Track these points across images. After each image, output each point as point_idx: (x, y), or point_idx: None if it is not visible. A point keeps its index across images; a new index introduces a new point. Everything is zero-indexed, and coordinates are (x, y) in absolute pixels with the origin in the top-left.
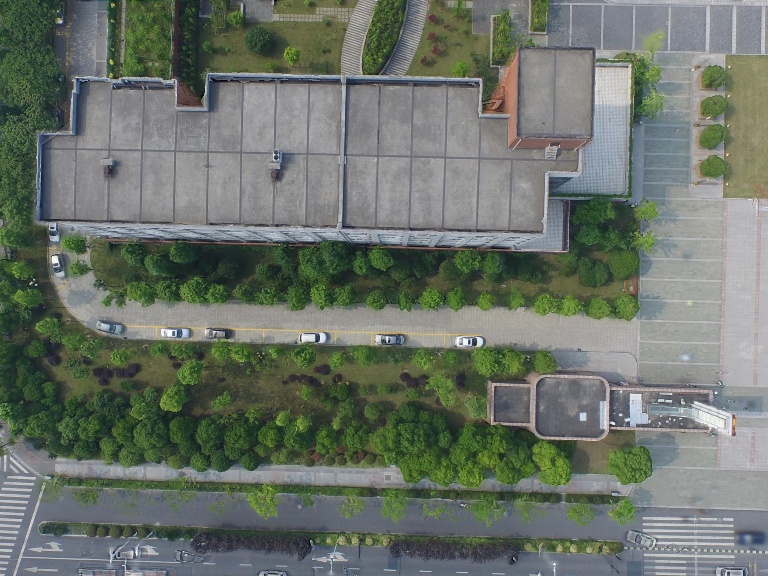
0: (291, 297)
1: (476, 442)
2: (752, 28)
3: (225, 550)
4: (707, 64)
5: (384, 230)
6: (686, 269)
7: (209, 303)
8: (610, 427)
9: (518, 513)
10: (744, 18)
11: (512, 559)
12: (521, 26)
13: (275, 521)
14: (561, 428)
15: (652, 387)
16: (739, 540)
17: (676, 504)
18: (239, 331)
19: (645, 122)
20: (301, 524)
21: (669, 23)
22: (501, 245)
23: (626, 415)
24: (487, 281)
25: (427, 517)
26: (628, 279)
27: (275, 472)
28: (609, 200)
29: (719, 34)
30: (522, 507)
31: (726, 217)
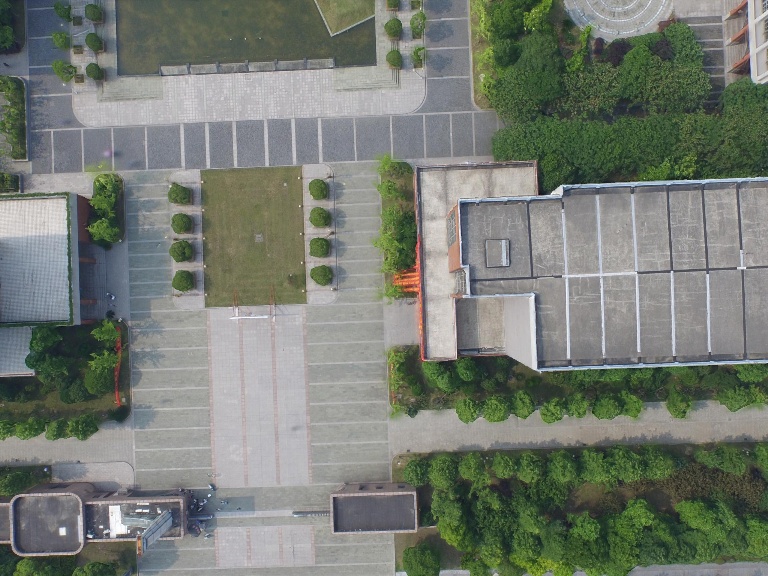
0: None
1: None
2: (224, 143)
3: None
4: (183, 180)
5: None
6: (175, 378)
7: None
8: (87, 540)
9: None
10: (216, 134)
11: None
12: (6, 154)
13: None
14: (42, 544)
15: (130, 498)
16: None
17: None
18: None
19: (128, 239)
20: None
21: (146, 143)
22: None
23: (106, 527)
24: None
25: None
26: (115, 392)
27: None
28: (58, 326)
29: (193, 150)
30: None
31: (209, 326)
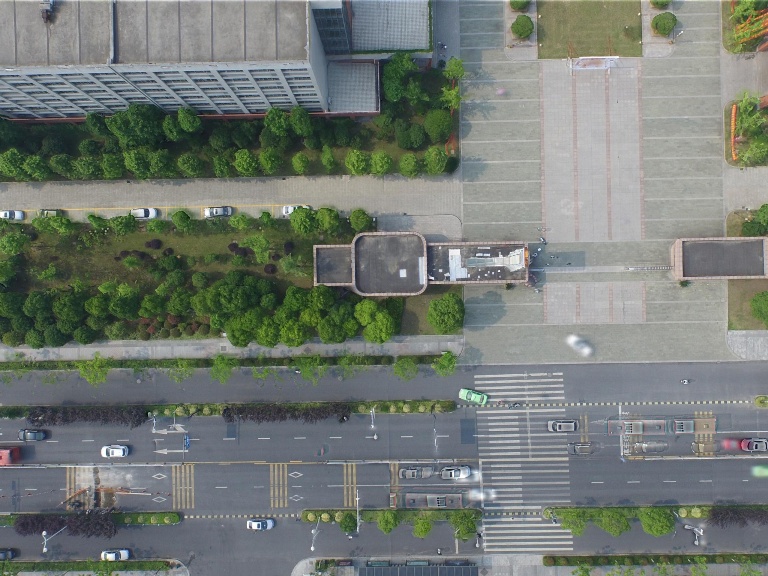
0: (103, 162)
1: (295, 299)
2: None
3: (61, 423)
4: None
5: (152, 63)
6: (505, 130)
7: (41, 185)
8: (429, 282)
9: (352, 377)
10: None
11: (342, 418)
12: None
13: (115, 396)
14: (382, 285)
15: None
16: (569, 393)
17: (506, 361)
18: (72, 211)
19: None
20: (140, 398)
21: None
22: (309, 104)
23: (446, 270)
24: (310, 150)
25: (263, 385)
26: (447, 141)
27: (113, 348)
28: (413, 56)
29: None
30: (356, 371)
31: (542, 78)
